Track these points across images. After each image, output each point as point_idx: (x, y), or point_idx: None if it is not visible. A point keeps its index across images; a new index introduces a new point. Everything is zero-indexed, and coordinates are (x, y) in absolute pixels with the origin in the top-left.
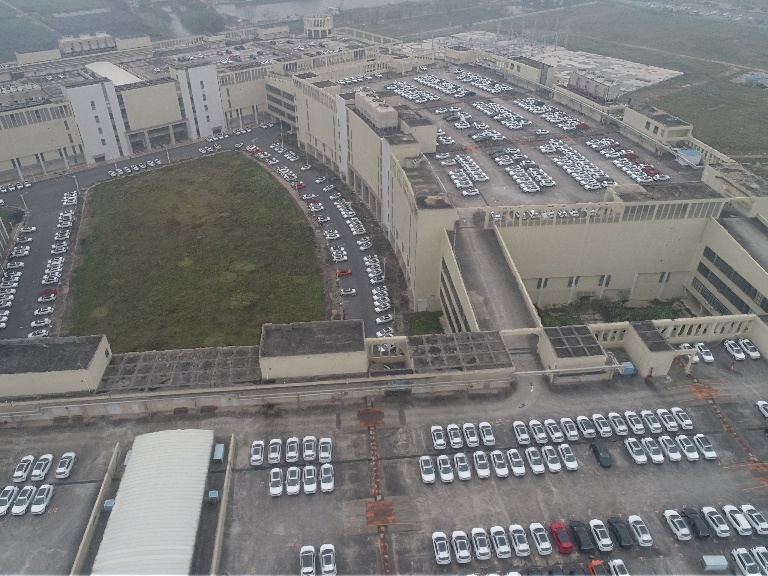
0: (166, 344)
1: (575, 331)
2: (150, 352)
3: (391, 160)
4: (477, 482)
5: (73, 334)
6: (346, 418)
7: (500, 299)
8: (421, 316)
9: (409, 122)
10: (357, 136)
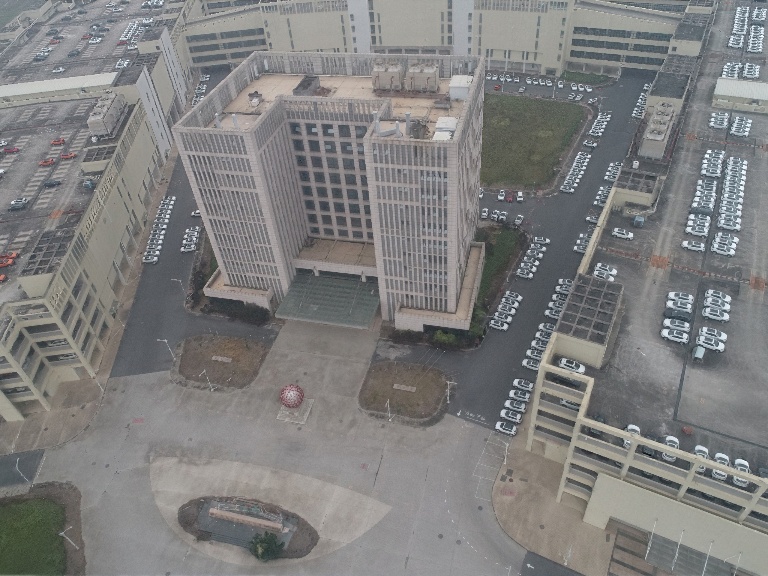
0: (532, 149)
1: (694, 1)
2: None
3: (477, 1)
4: (763, 45)
5: (491, 180)
6: (712, 60)
7: (642, 16)
8: (566, 75)
9: None
10: (391, 15)
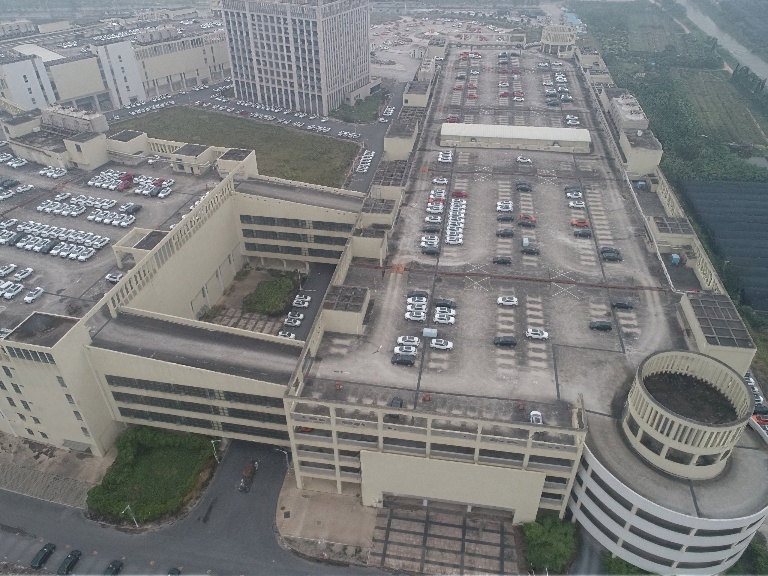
0: None
1: None
2: (87, 59)
3: None
4: None
5: None
6: None
7: None
8: None
9: (30, 118)
10: None
